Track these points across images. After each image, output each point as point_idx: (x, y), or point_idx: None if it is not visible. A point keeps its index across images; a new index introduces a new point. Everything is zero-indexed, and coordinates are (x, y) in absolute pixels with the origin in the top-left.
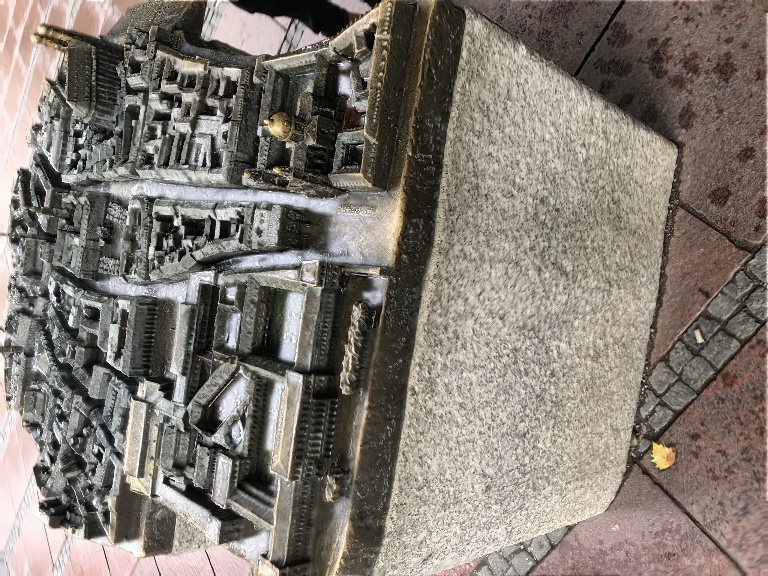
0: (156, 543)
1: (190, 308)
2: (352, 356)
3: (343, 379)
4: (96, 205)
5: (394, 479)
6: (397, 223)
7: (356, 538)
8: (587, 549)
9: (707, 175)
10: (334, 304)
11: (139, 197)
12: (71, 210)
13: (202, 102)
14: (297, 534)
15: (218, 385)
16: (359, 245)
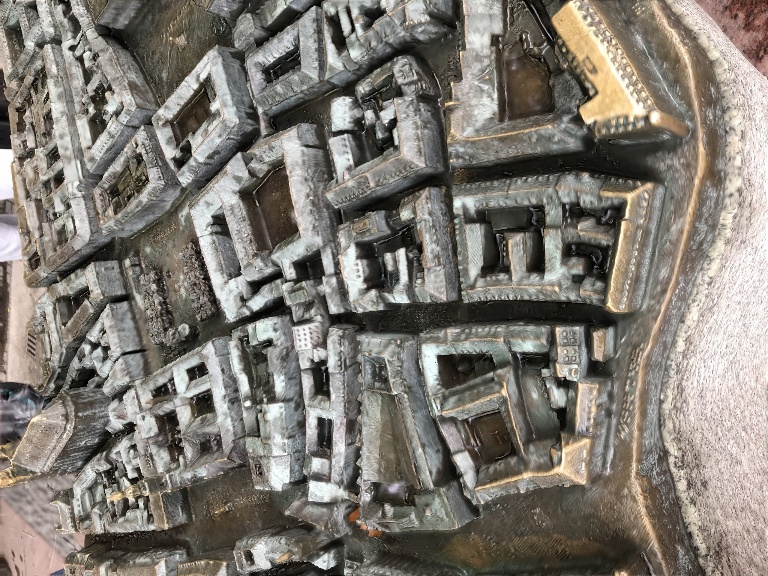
0: None
1: None
2: None
3: None
4: None
5: None
6: None
7: None
8: None
9: None
10: None
11: None
12: None
13: None
14: None
15: None
16: None
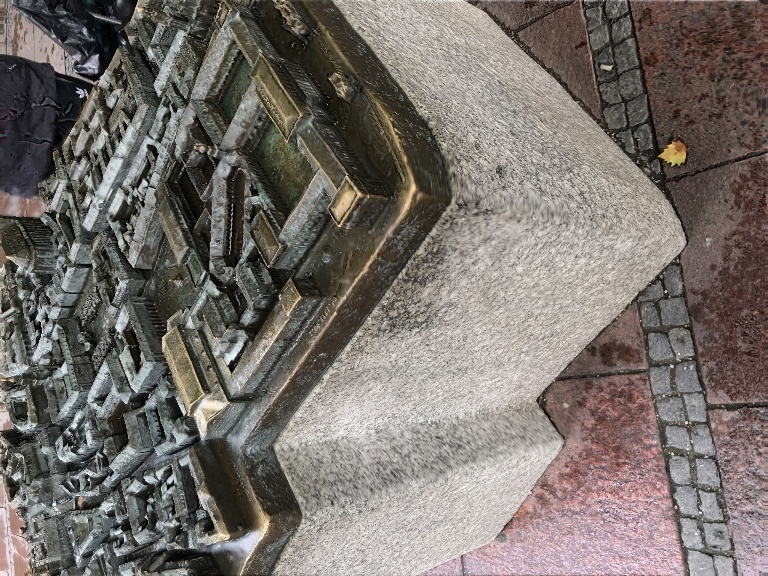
0: (276, 502)
1: (166, 198)
2: (285, 4)
3: (291, 23)
4: (69, 328)
5: (398, 84)
6: None
7: (394, 110)
8: (711, 288)
9: (513, 2)
10: (258, 28)
11: None
12: (51, 368)
13: (106, 114)
14: (346, 161)
15: (222, 218)
16: None
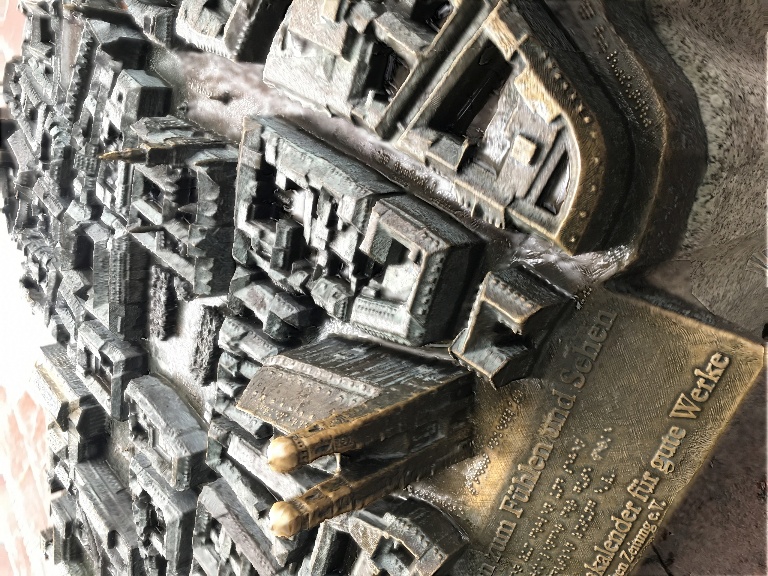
0: None
1: None
2: None
3: None
4: None
5: None
6: None
7: None
8: None
9: None
10: None
11: (182, 479)
12: None
13: None
14: None
15: None
16: None
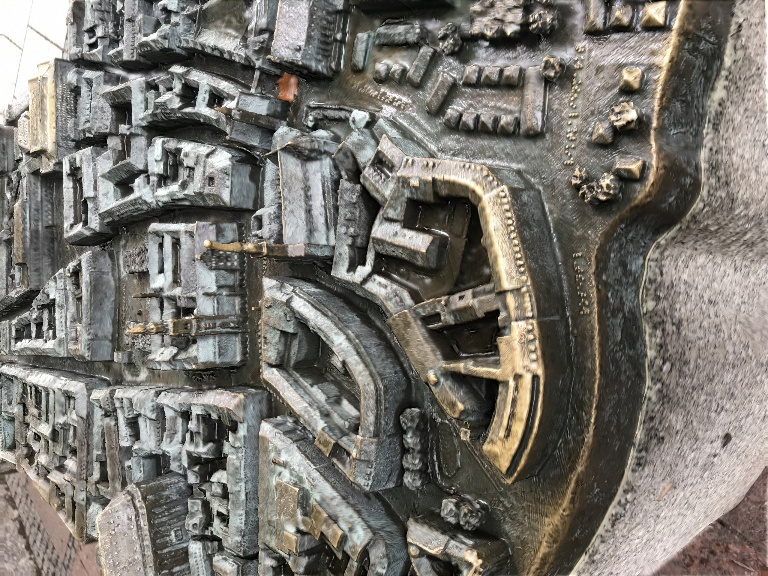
0: None
1: None
2: None
3: None
4: None
5: None
6: None
7: None
8: None
9: None
10: None
11: None
12: None
13: None
14: None
15: None
16: None
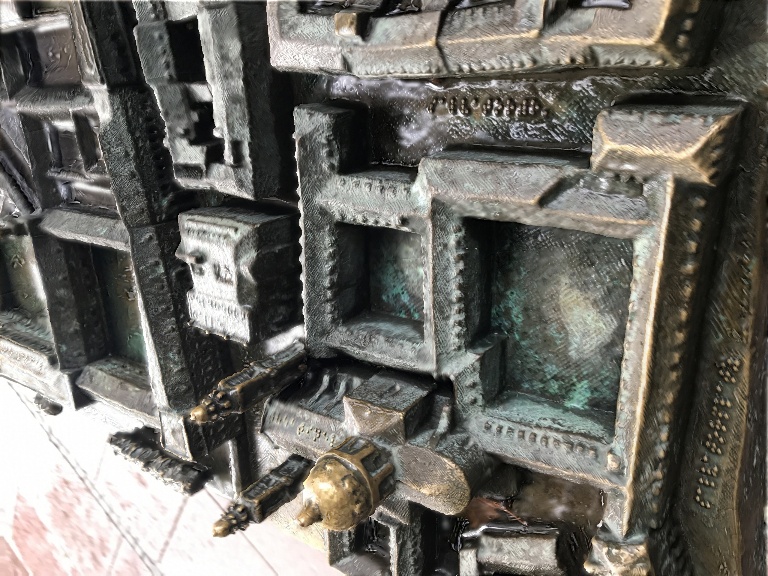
0: None
1: (15, 17)
2: None
3: None
4: None
5: None
6: (310, 544)
7: None
8: None
9: None
10: None
11: None
12: None
13: None
14: None
15: None
16: (273, 458)
